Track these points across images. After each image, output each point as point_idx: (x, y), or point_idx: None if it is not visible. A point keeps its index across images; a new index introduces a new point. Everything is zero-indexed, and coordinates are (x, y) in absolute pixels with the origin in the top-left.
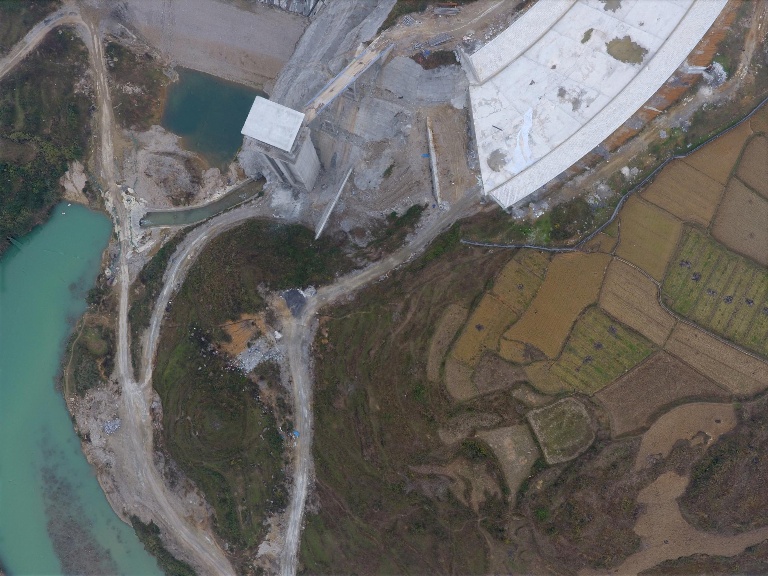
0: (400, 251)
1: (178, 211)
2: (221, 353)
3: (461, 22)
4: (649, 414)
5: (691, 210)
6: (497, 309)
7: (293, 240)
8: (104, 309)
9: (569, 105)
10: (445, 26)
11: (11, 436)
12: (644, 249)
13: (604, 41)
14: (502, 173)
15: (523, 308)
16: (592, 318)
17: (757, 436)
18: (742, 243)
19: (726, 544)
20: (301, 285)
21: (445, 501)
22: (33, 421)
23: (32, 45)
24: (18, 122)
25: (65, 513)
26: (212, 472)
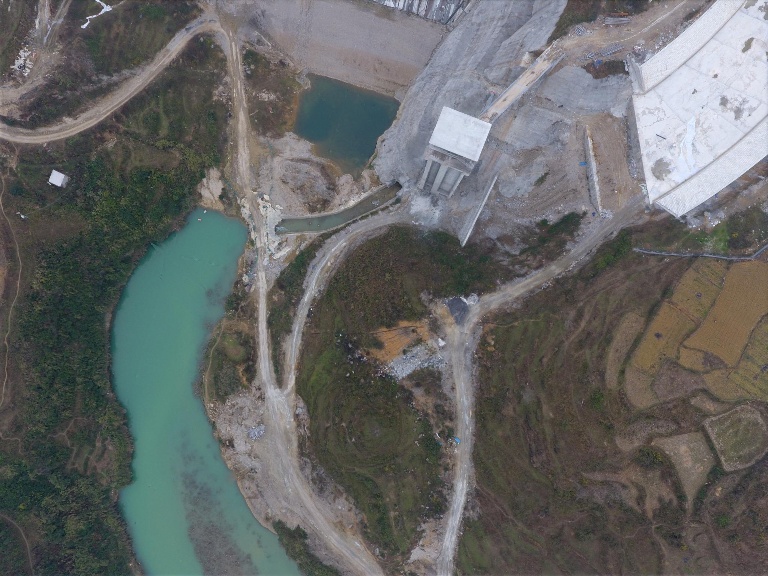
0: (562, 259)
1: (313, 218)
2: (370, 360)
3: (631, 32)
4: None
5: None
6: (675, 317)
7: (442, 247)
8: (243, 315)
9: (731, 114)
10: (616, 36)
11: (150, 442)
12: None
13: (764, 50)
14: (666, 182)
15: (702, 316)
16: None
17: None
18: None
19: None
20: (463, 293)
21: (616, 508)
22: (170, 427)
23: (175, 53)
24: (162, 129)
25: (206, 518)
26: (364, 478)
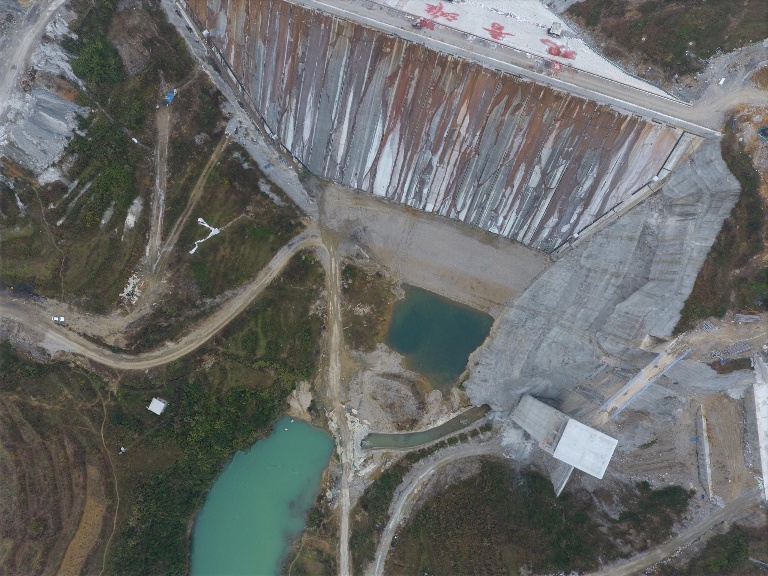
0: (668, 543)
1: (399, 434)
2: None
3: (761, 330)
4: None
5: None
6: None
7: (537, 499)
8: (325, 534)
9: None
10: (745, 333)
11: None
12: None
13: None
14: None
15: None
16: None
17: None
18: None
19: None
20: (563, 569)
21: None
22: None
23: (276, 271)
24: (260, 349)
25: None
26: None
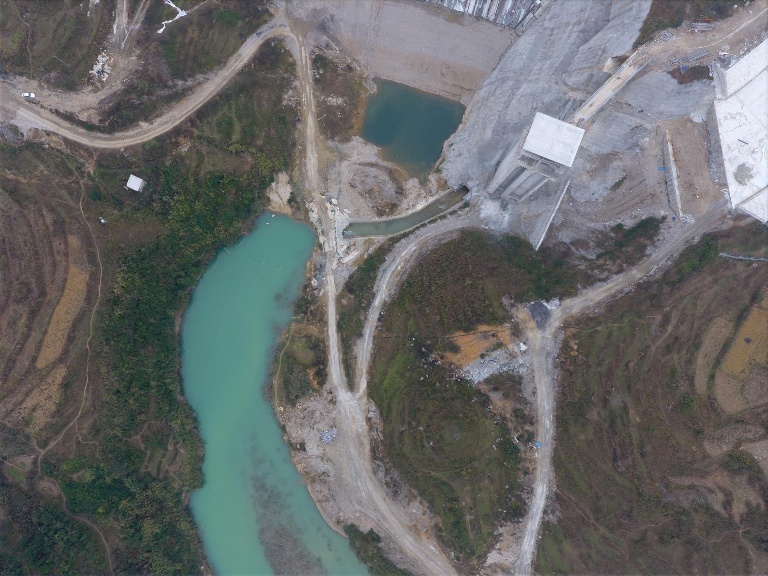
0: (643, 264)
1: (380, 222)
2: (444, 364)
3: (716, 37)
4: None
5: None
6: (765, 322)
7: (517, 252)
8: (313, 319)
9: None
10: (701, 41)
11: (220, 445)
12: None
13: None
14: (749, 187)
15: None
16: None
17: None
18: None
19: None
20: (544, 297)
21: (702, 512)
22: (239, 430)
23: (247, 57)
24: (235, 134)
25: (276, 521)
26: (441, 482)
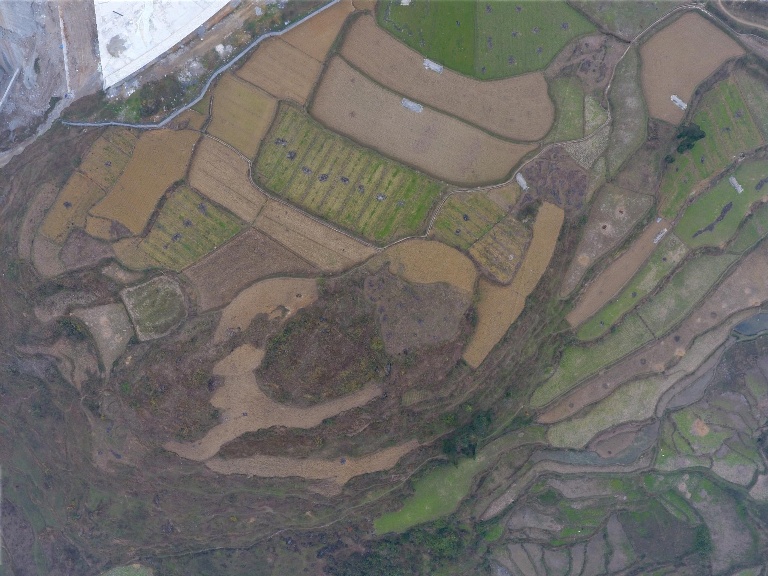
0: (29, 140)
1: None
2: None
3: None
4: (236, 290)
5: (287, 88)
6: (86, 187)
7: None
8: None
9: None
10: None
11: None
12: (236, 127)
13: None
14: (121, 59)
15: (110, 185)
16: (182, 196)
17: (330, 308)
18: (342, 122)
19: (303, 416)
20: None
21: (56, 382)
22: None
23: None
24: None
25: None
26: None
